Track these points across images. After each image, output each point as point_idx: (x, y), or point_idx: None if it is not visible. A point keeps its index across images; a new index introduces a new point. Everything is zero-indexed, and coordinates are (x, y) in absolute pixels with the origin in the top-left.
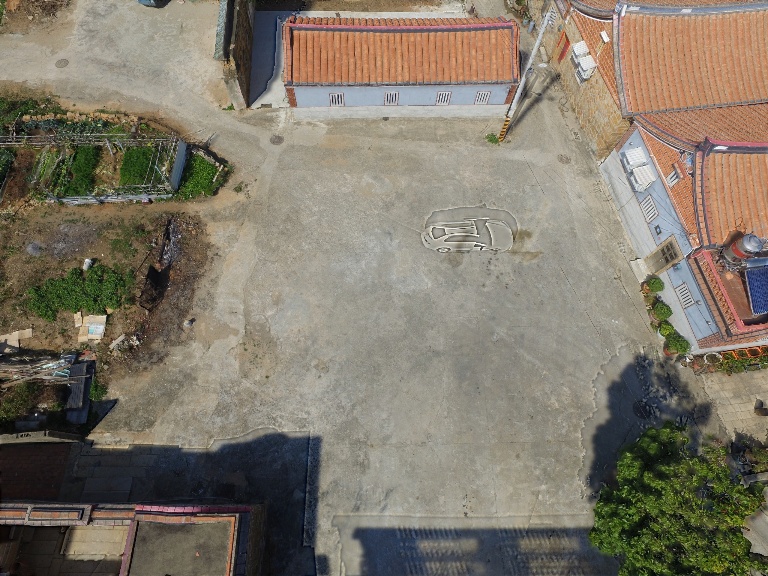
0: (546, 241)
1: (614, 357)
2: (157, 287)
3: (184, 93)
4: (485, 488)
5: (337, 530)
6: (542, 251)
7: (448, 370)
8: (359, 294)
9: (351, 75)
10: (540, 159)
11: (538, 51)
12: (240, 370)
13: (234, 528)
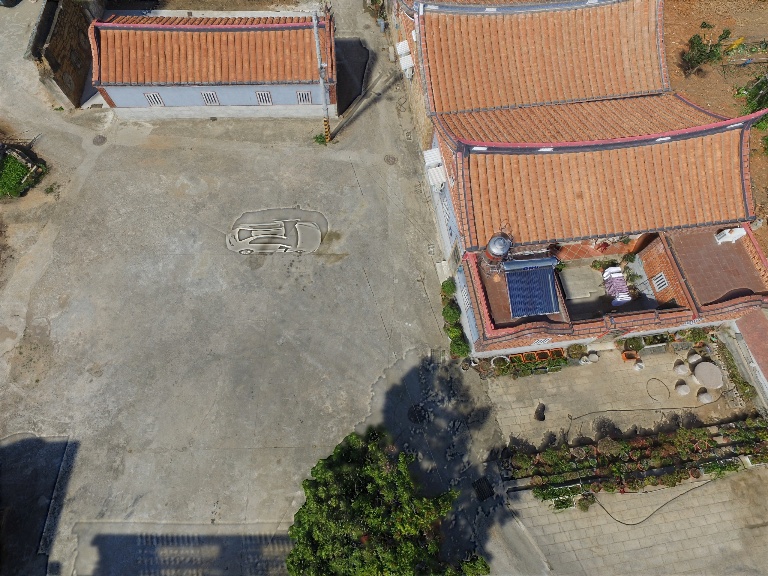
0: (354, 243)
1: (399, 361)
2: None
3: (18, 93)
4: (238, 494)
5: (76, 537)
6: (348, 253)
7: (225, 374)
8: (150, 297)
9: (161, 75)
10: (366, 160)
11: (387, 50)
12: (10, 374)
13: None
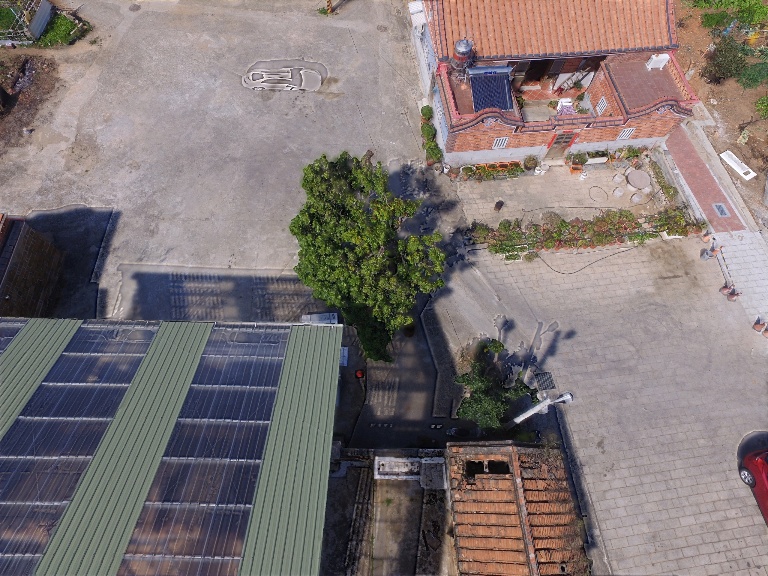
0: (350, 86)
1: (384, 167)
2: (5, 105)
3: None
4: (250, 250)
5: (121, 273)
6: (344, 92)
7: (240, 171)
8: (178, 117)
9: None
10: (361, 27)
11: None
12: (65, 165)
13: (1, 221)
